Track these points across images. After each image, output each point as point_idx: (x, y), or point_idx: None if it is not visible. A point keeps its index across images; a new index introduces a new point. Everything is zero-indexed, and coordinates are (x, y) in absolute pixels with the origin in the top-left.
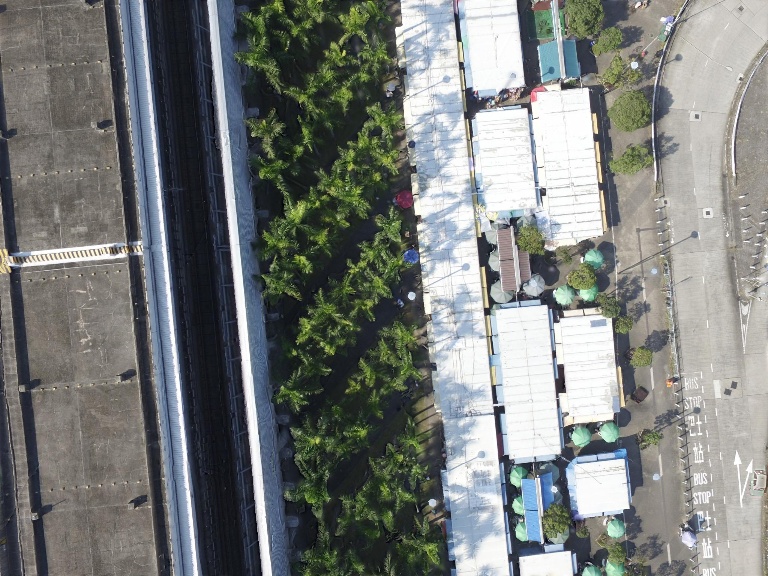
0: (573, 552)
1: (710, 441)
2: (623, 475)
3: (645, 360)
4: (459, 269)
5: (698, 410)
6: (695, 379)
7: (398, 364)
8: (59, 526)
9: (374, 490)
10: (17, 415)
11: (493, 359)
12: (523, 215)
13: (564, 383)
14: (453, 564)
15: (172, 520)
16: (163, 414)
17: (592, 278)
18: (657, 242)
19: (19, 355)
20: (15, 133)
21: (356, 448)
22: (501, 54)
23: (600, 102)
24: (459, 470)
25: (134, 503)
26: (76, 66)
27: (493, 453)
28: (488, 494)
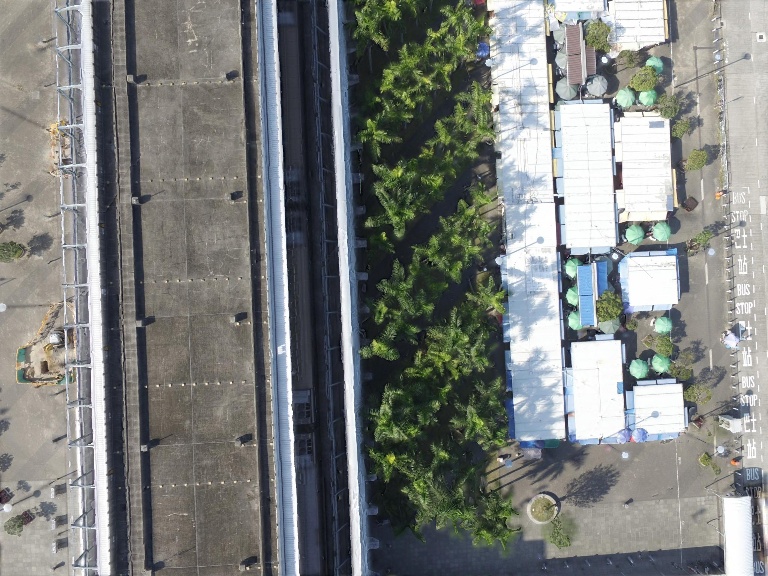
0: (623, 342)
1: (754, 254)
2: (673, 271)
3: (700, 159)
4: (527, 63)
5: (744, 223)
6: (742, 194)
7: (472, 129)
8: (156, 215)
9: (445, 241)
10: (123, 105)
11: (555, 152)
12: (590, 18)
13: (621, 182)
14: (508, 345)
15: (266, 215)
16: (263, 115)
17: (654, 76)
18: (712, 60)
19: (128, 49)
20: None
21: (427, 208)
22: None
23: None
24: (518, 254)
25: (231, 195)
26: None
27: (552, 239)
28: (545, 280)
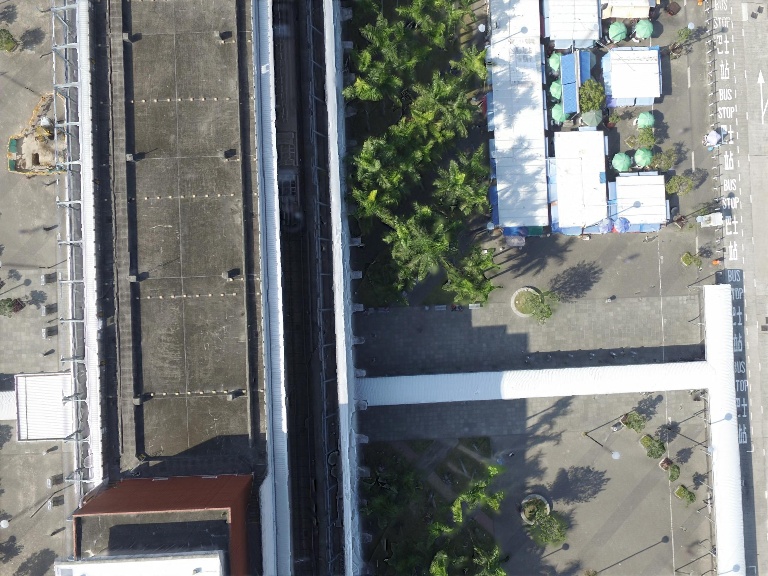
0: (605, 134)
1: (736, 59)
2: (656, 65)
3: None
4: None
5: (726, 29)
6: (725, 0)
7: None
8: None
9: (429, 5)
10: None
11: None
12: None
13: None
14: (492, 134)
15: None
16: None
17: None
18: None
19: None
20: None
21: None
22: None
23: None
24: (502, 44)
25: None
26: None
27: (535, 30)
28: (528, 70)
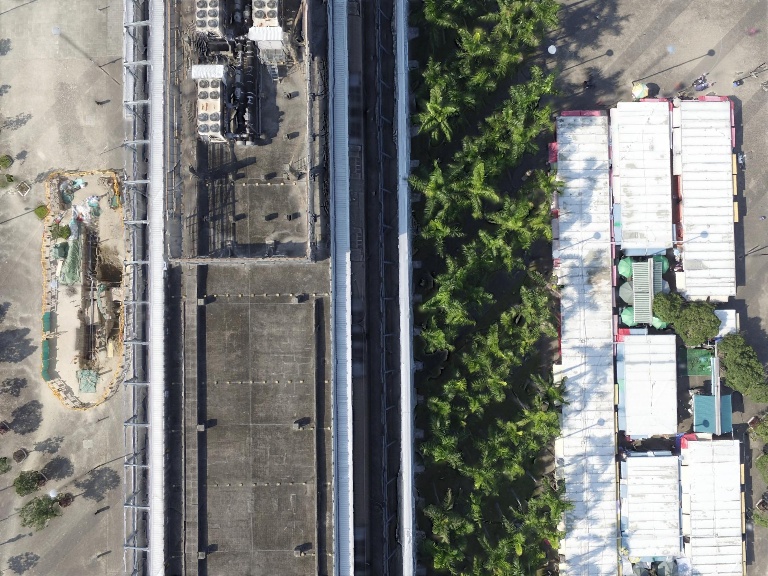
0: None
1: None
2: None
3: None
4: None
5: None
6: None
7: None
8: None
9: None
10: None
11: None
12: (665, 561)
13: None
14: None
15: None
16: None
17: None
18: None
19: None
20: (215, 549)
21: None
22: (656, 401)
23: (744, 441)
24: None
25: None
26: (281, 486)
27: None
28: None
